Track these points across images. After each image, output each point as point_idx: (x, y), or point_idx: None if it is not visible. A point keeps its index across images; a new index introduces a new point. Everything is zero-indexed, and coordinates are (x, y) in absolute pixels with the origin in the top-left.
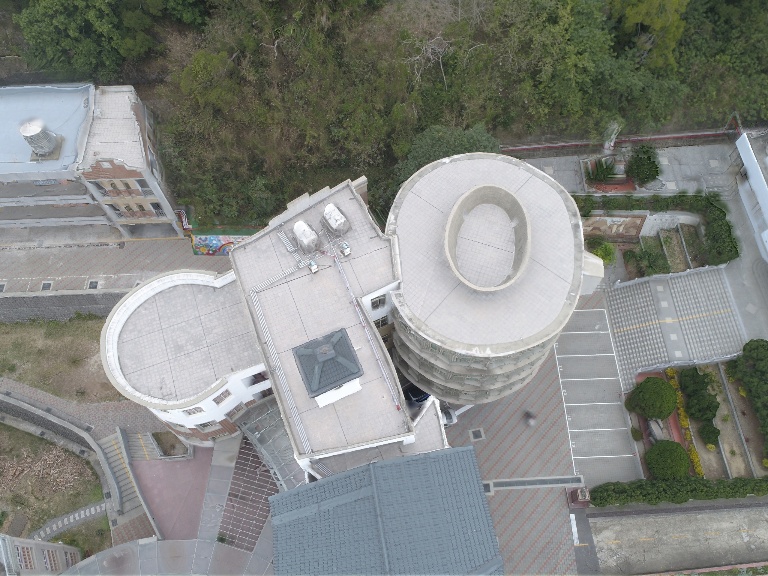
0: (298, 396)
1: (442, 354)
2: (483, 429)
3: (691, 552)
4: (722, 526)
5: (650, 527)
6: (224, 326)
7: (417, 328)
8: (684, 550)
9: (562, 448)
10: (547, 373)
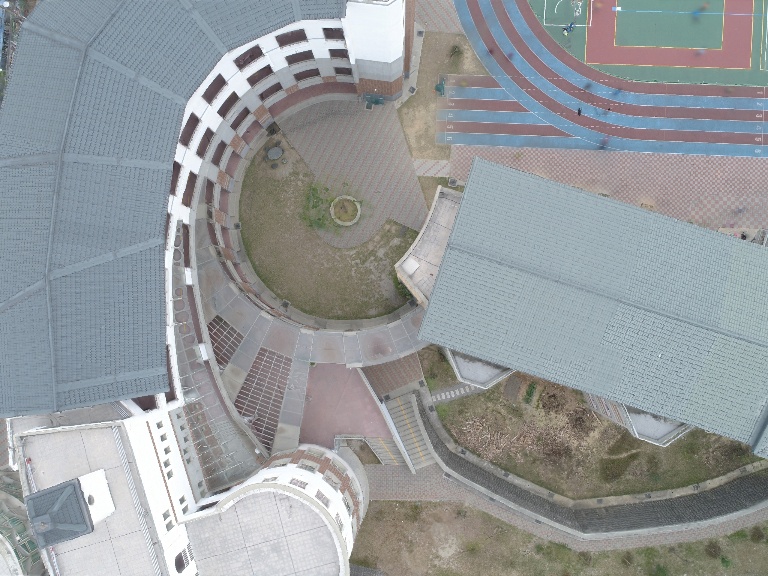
0: (124, 483)
1: (3, 512)
2: None
3: None
4: None
5: None
6: (230, 569)
7: (3, 542)
8: None
9: None
10: None
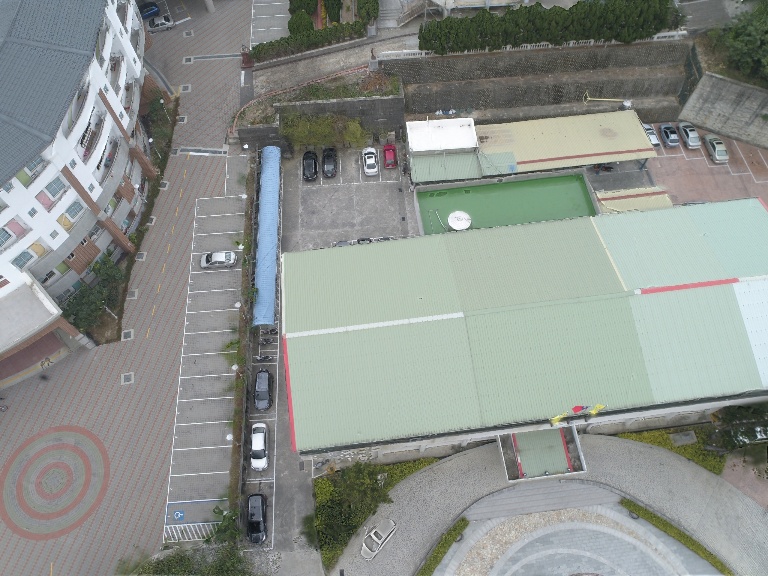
0: None
1: None
2: (193, 31)
3: (309, 77)
4: (330, 61)
5: (288, 70)
6: None
7: None
8: (305, 77)
9: (245, 39)
10: (245, 2)
